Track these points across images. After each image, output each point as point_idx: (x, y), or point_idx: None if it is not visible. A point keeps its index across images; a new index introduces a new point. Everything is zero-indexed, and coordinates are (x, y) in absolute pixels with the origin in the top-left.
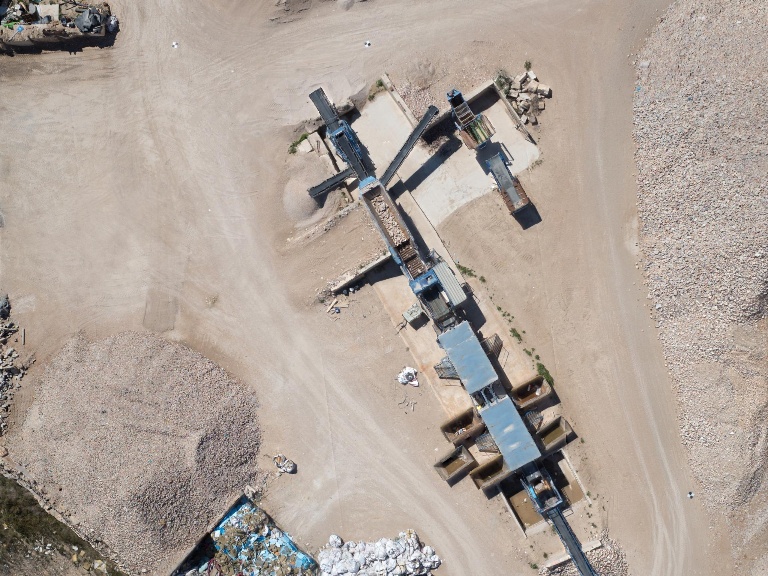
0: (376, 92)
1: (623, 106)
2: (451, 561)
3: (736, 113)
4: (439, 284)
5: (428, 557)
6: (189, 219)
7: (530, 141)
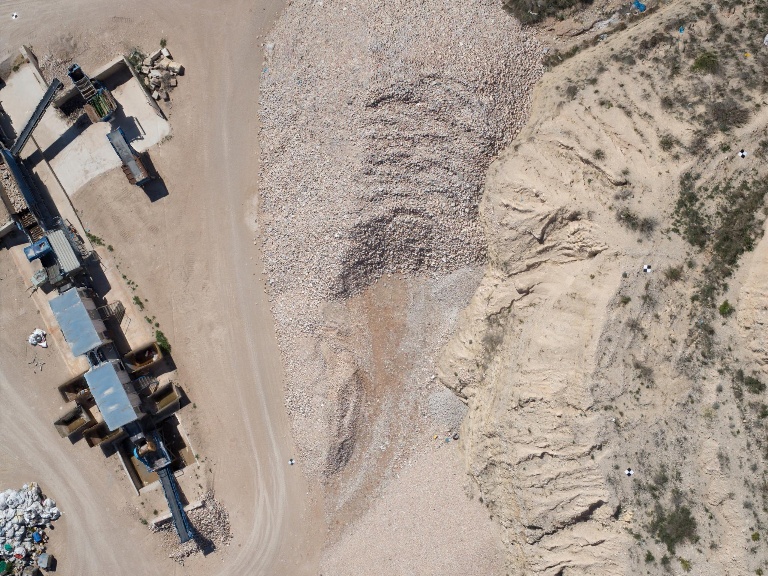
0: (20, 63)
1: (250, 86)
2: (70, 514)
3: (327, 98)
4: None
5: (46, 509)
6: None
7: (162, 117)
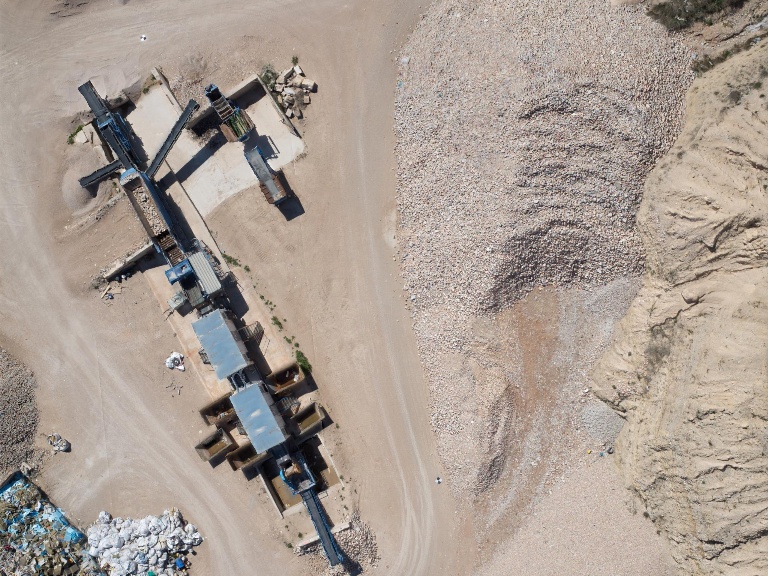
0: (150, 85)
1: (385, 101)
2: (212, 539)
3: (474, 110)
4: None
5: (189, 534)
6: None
7: (295, 135)
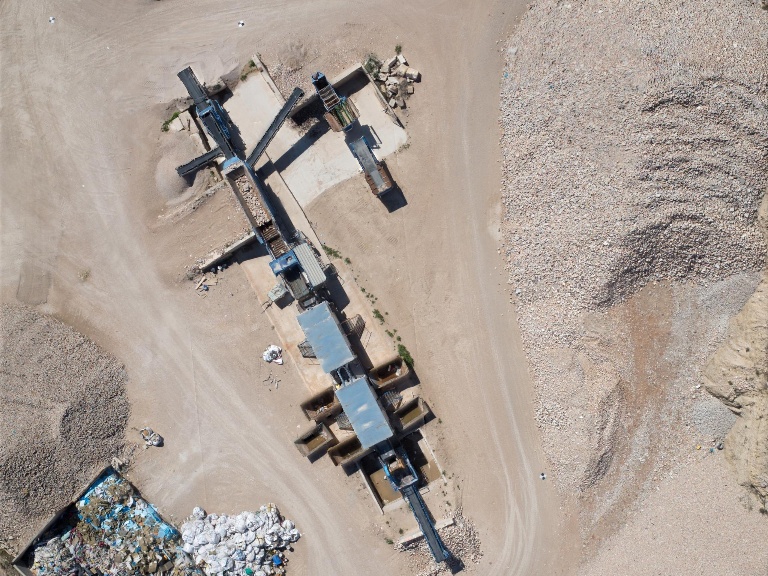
0: (248, 72)
1: (490, 92)
2: (310, 535)
3: (591, 103)
4: (300, 265)
5: (287, 531)
6: (63, 194)
7: (398, 125)
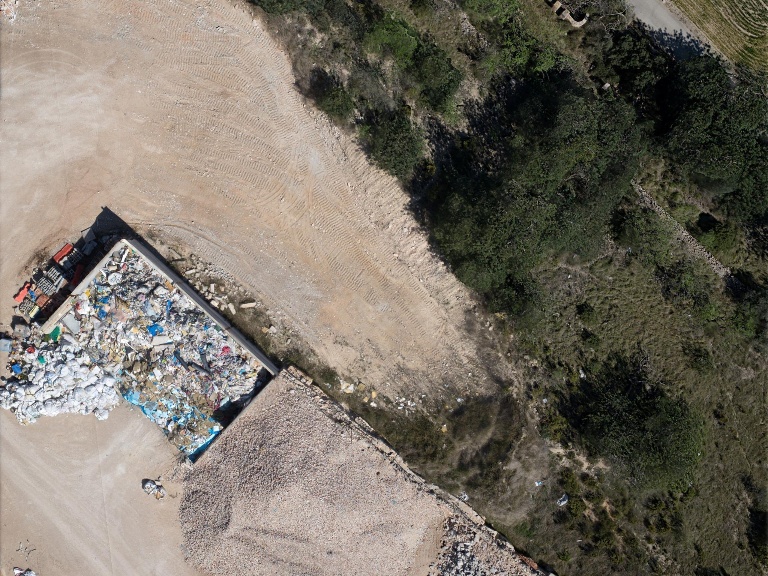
0: None
1: None
2: None
3: None
4: None
5: (4, 401)
6: None
7: None
